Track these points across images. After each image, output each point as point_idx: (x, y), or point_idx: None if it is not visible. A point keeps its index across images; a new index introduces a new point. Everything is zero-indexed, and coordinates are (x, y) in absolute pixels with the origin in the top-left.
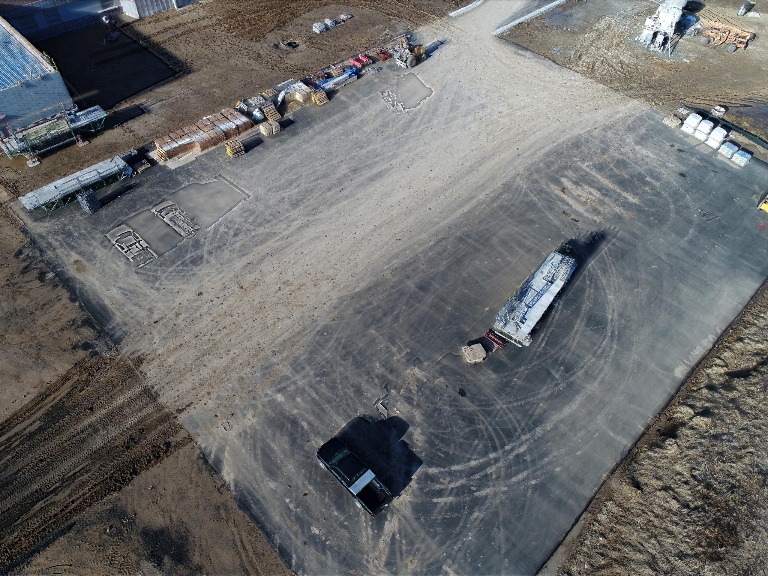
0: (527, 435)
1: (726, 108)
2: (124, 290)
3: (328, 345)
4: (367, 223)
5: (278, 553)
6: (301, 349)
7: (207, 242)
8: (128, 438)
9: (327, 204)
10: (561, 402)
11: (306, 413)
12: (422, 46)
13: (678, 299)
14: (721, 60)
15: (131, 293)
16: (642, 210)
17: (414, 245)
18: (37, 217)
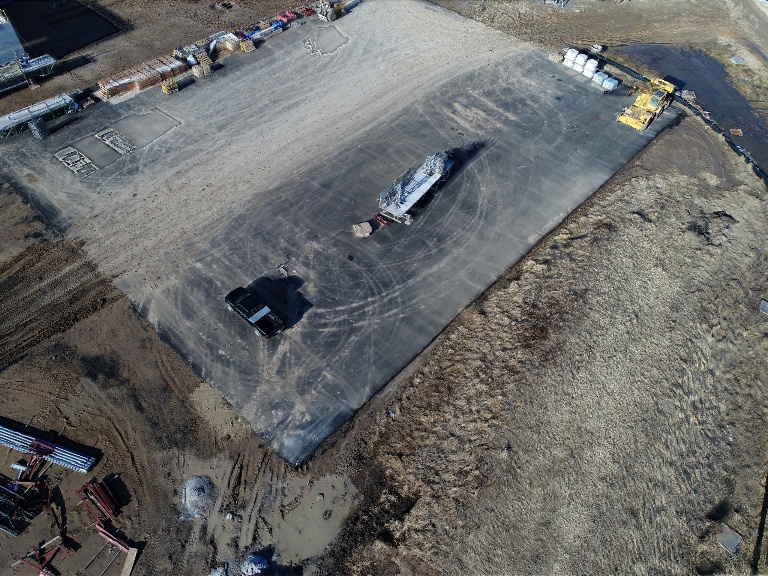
0: (400, 285)
1: (606, 47)
2: (69, 194)
3: (241, 228)
4: (282, 140)
5: (191, 368)
6: (218, 231)
7: (142, 158)
8: (71, 296)
9: (248, 127)
10: (431, 262)
11: (220, 275)
12: (341, 2)
13: (539, 189)
14: (608, 10)
15: (75, 196)
16: (519, 125)
17: (321, 155)
18: None
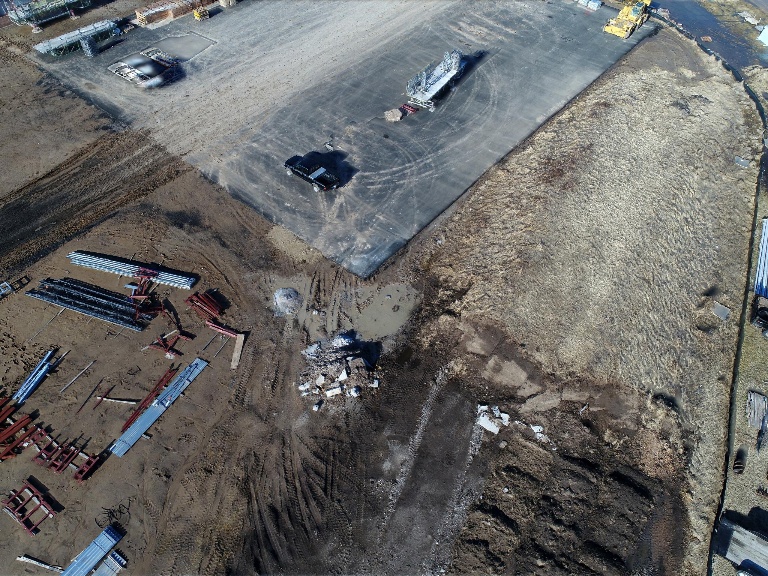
0: (432, 154)
1: None
2: (128, 97)
3: (287, 117)
4: (310, 53)
5: (263, 216)
6: (267, 120)
7: (187, 69)
8: (147, 170)
9: (278, 44)
10: (456, 138)
11: (275, 151)
12: None
13: (541, 83)
14: None
15: (134, 98)
16: (518, 37)
17: (347, 63)
18: (49, 61)
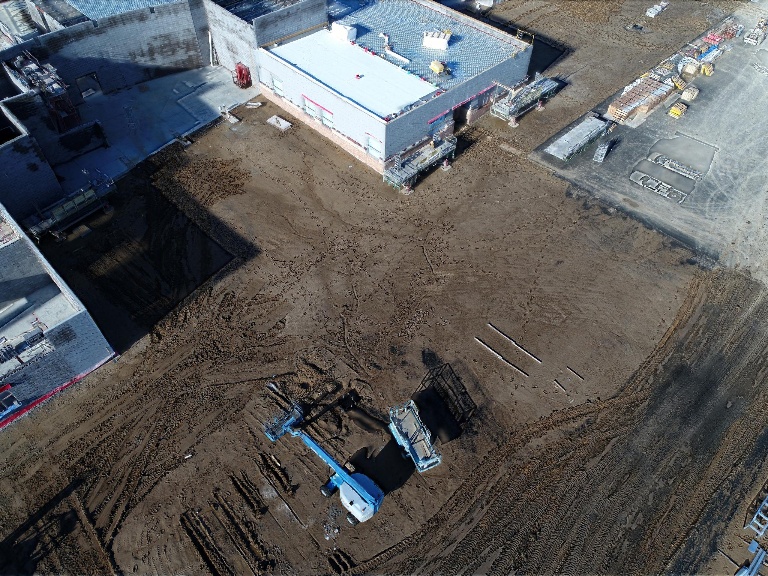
0: None
1: None
2: (685, 220)
3: None
4: None
5: None
6: None
7: (717, 184)
8: None
9: None
10: None
11: None
12: (766, 26)
13: None
14: None
15: (693, 222)
16: None
17: None
18: (560, 166)
